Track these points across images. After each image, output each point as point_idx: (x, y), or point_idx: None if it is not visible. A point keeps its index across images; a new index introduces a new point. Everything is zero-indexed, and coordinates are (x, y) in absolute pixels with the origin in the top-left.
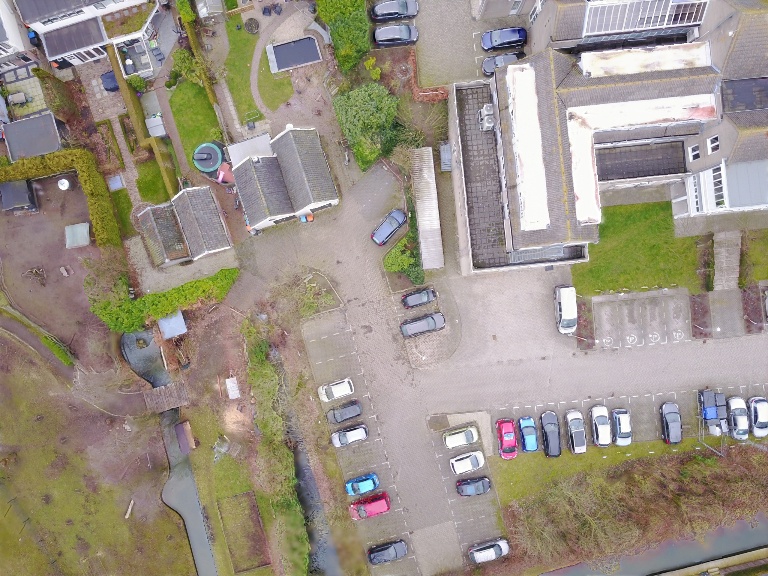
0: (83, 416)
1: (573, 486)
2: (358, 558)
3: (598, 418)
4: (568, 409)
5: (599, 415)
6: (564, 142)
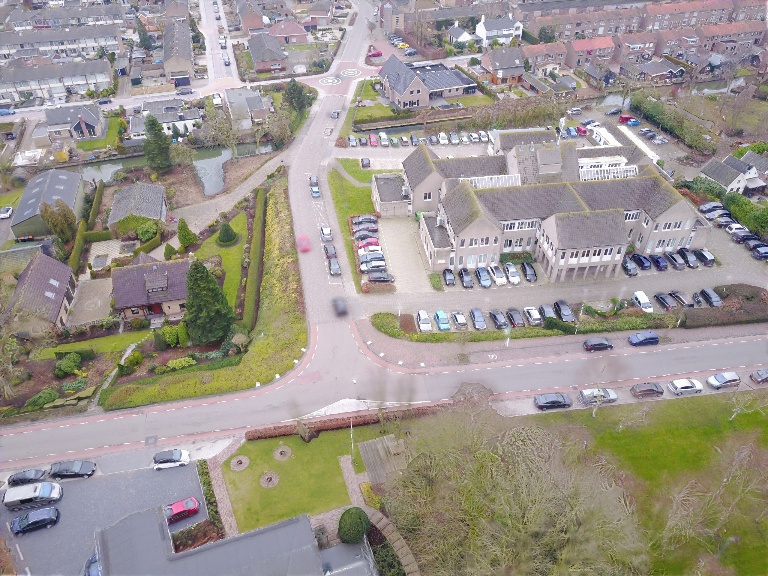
0: (764, 135)
1: (546, 124)
2: (624, 112)
3: None
4: None
5: None
6: (623, 138)
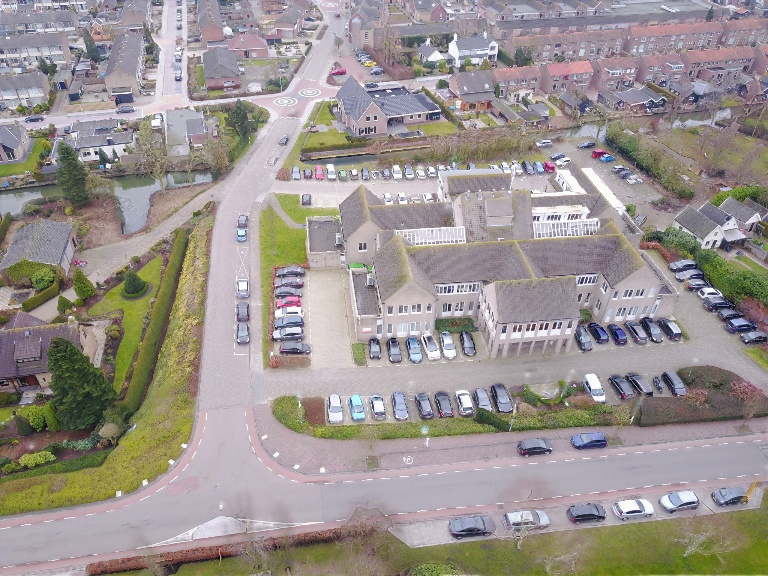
0: (747, 176)
1: (512, 158)
2: None
3: (509, 170)
4: (521, 175)
5: (509, 170)
6: (587, 184)
